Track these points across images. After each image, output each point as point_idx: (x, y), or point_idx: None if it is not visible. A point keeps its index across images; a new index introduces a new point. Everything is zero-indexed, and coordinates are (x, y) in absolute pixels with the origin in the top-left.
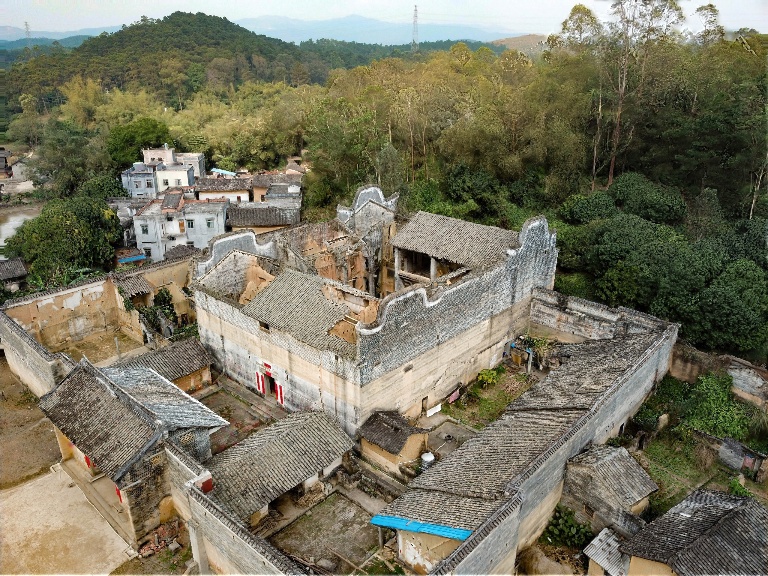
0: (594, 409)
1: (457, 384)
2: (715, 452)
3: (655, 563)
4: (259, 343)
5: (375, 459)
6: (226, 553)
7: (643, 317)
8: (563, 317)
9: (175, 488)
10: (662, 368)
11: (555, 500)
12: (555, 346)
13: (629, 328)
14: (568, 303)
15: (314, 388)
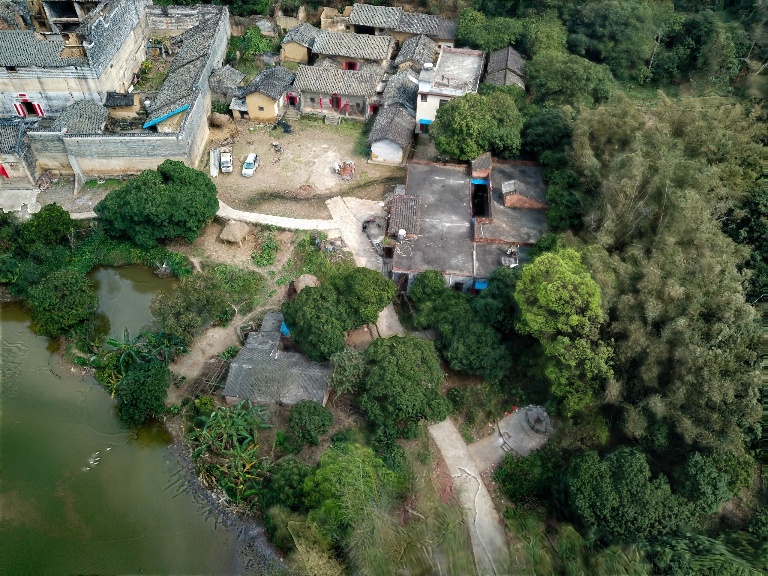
0: (209, 52)
1: (133, 74)
2: (262, 60)
3: (253, 94)
4: (10, 83)
5: (120, 116)
6: (96, 155)
7: (209, 7)
8: (168, 20)
9: (40, 153)
10: (228, 32)
11: (210, 98)
12: (171, 40)
13: (205, 16)
14: (168, 11)
15: (65, 94)
